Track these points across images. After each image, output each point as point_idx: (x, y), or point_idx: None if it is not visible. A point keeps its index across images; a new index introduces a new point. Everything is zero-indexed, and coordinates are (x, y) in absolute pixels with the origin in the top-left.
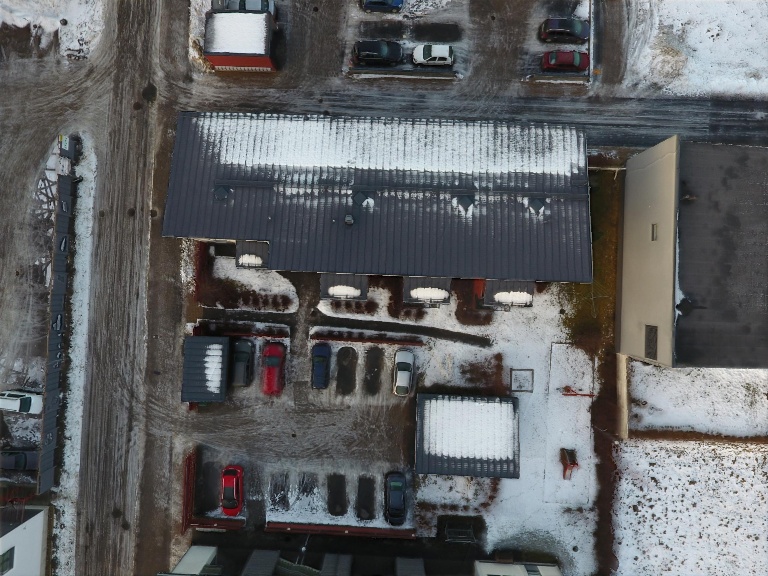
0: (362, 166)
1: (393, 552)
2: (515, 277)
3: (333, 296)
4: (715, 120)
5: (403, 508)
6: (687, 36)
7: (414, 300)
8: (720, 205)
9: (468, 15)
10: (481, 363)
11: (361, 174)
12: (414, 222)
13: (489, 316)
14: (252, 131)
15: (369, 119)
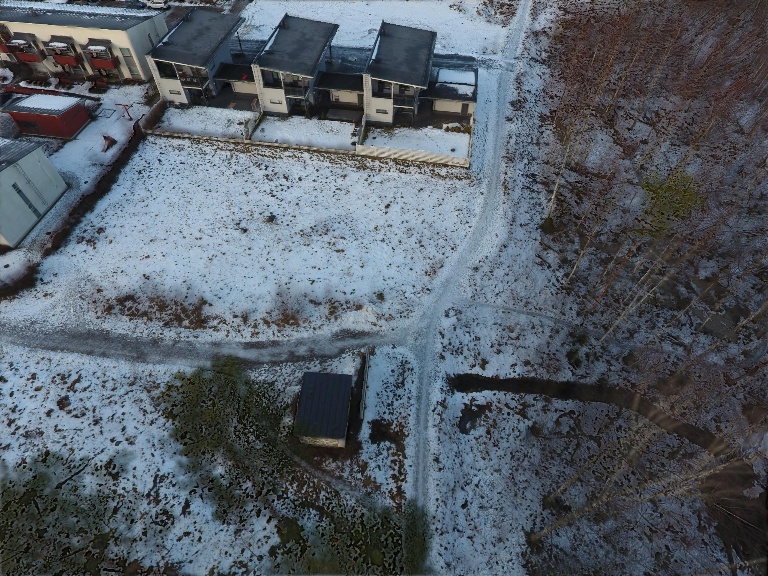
0: (58, 9)
1: None
2: (91, 27)
3: (12, 43)
4: (260, 46)
5: None
6: (260, 27)
7: (49, 46)
8: (204, 24)
9: (166, 17)
10: (89, 106)
11: (55, 10)
12: (63, 17)
13: (106, 90)
14: (22, 2)
15: (75, 4)
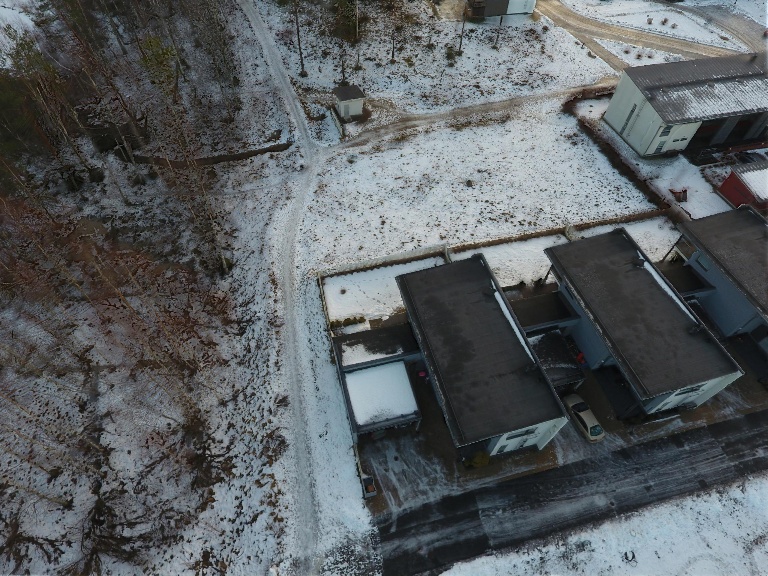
0: None
1: (726, 145)
2: None
3: None
4: None
5: (750, 156)
6: None
7: None
8: None
9: None
10: None
11: None
12: None
13: None
14: None
15: None
